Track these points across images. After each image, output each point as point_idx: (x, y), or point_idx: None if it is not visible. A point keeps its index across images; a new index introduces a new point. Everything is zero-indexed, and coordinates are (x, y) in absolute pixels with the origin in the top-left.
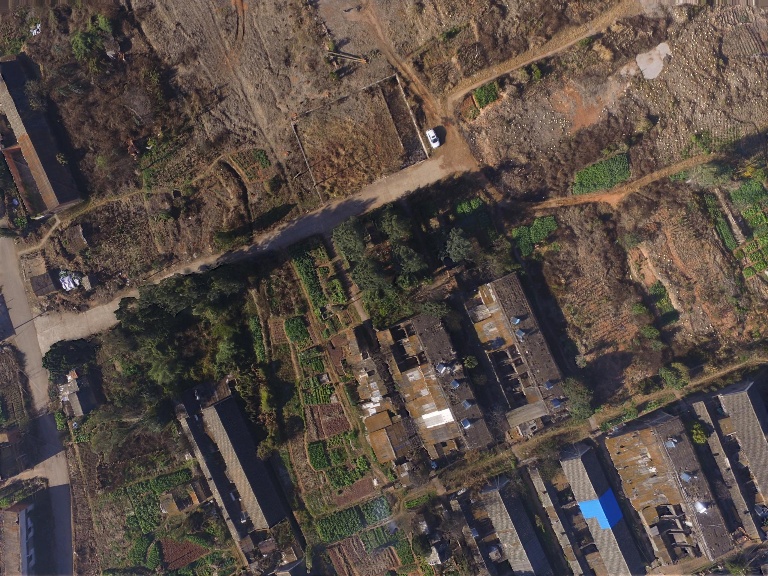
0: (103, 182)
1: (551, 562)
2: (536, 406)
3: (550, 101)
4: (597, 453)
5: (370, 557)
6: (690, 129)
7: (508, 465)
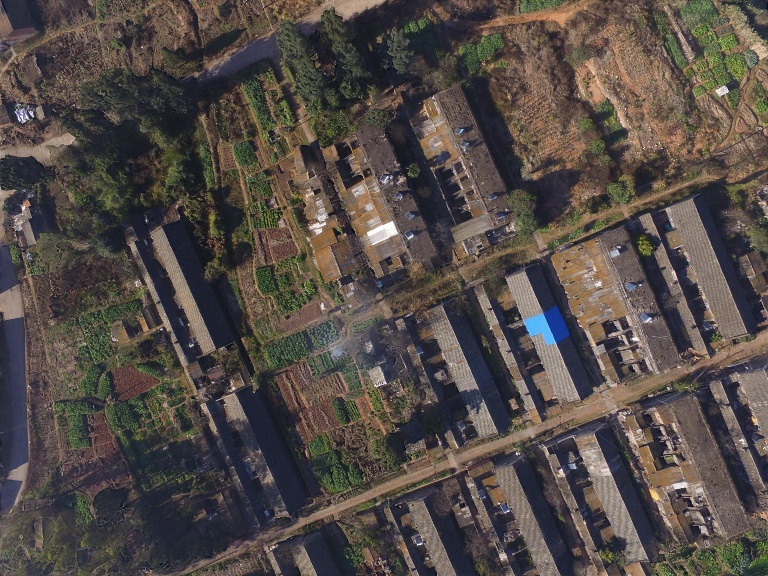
0: (57, 11)
1: (498, 386)
2: (481, 220)
3: None
4: (544, 271)
5: (317, 383)
6: None
7: (455, 287)
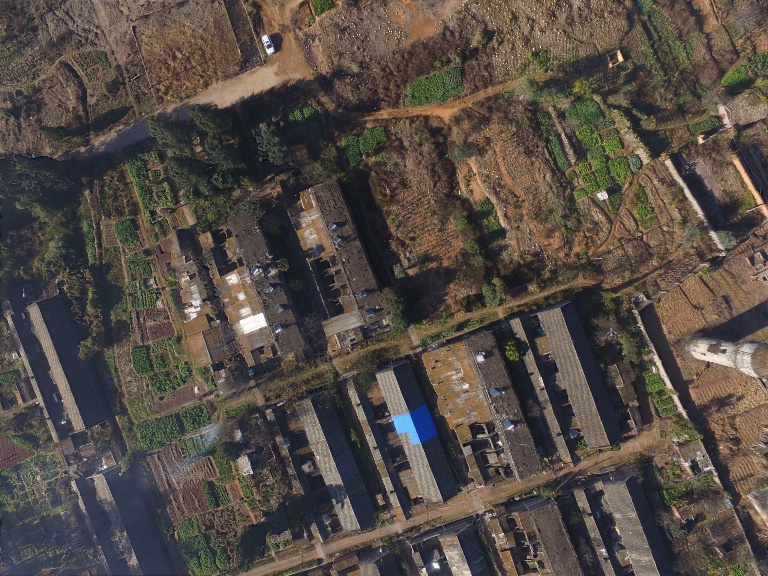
0: None
1: (367, 479)
2: (352, 316)
3: (386, 12)
4: (415, 369)
5: (189, 466)
6: (528, 47)
7: (328, 378)
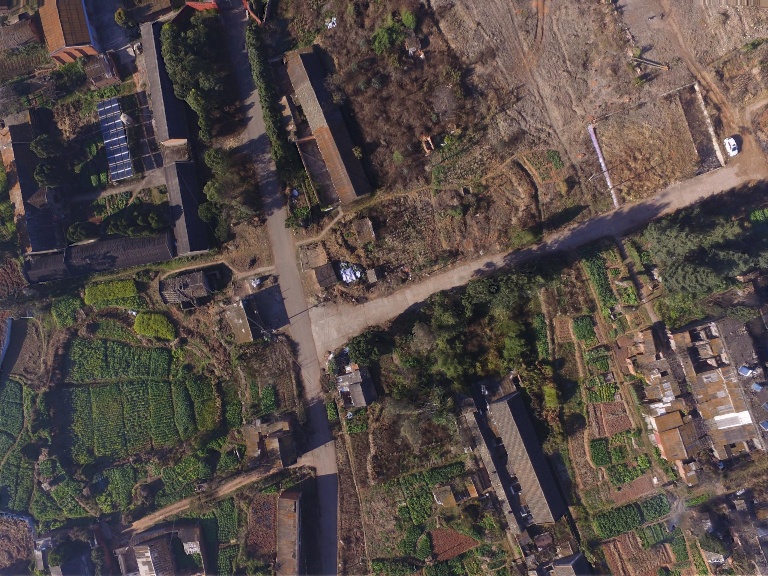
0: (395, 177)
1: None
2: None
3: None
4: None
5: (645, 553)
6: None
7: None
